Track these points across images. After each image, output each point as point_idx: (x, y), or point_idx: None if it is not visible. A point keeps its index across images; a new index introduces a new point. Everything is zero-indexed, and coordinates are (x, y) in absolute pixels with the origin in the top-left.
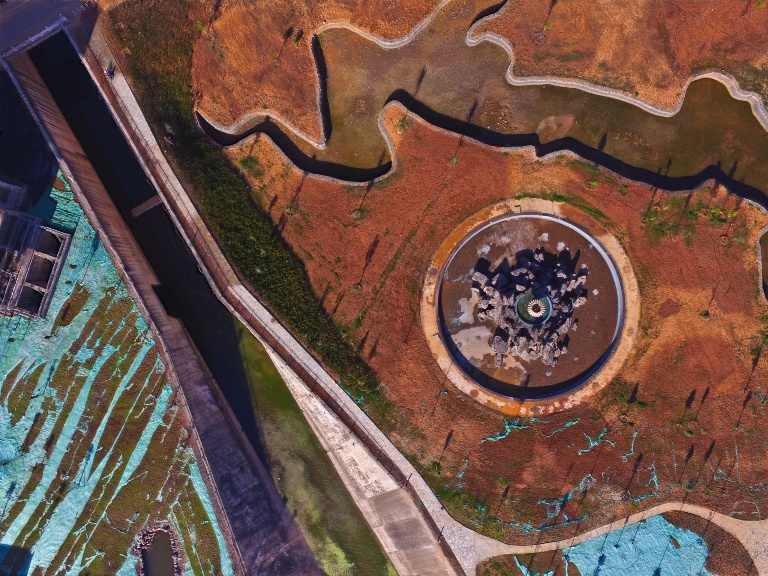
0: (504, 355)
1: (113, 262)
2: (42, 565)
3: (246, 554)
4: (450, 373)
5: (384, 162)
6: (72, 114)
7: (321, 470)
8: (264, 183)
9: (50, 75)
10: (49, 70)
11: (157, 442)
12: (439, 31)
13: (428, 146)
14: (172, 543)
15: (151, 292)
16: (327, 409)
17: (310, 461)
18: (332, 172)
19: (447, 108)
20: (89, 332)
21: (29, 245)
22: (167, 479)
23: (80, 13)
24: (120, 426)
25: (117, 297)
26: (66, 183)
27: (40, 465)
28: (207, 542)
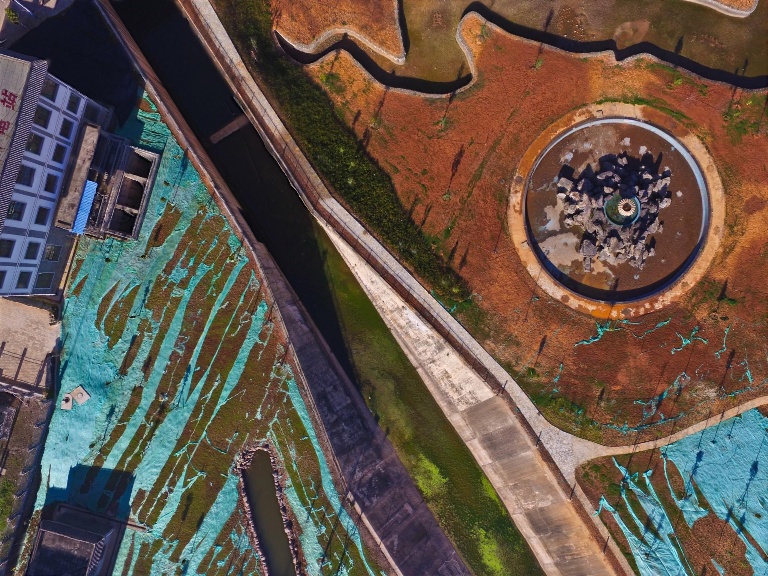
0: (592, 260)
1: (203, 181)
2: (144, 488)
3: (345, 469)
4: (540, 280)
5: (463, 75)
6: (142, 47)
7: (411, 387)
8: (346, 99)
9: (119, 8)
10: (118, 3)
11: (254, 360)
12: None
13: (508, 55)
14: (272, 461)
15: (239, 213)
16: (421, 319)
17: (400, 379)
18: (412, 87)
19: (523, 18)
20: (182, 252)
21: (120, 166)
22: (265, 396)
23: None
24: (217, 345)
25: (209, 216)
26: (152, 104)
27: (139, 387)
28: (307, 458)
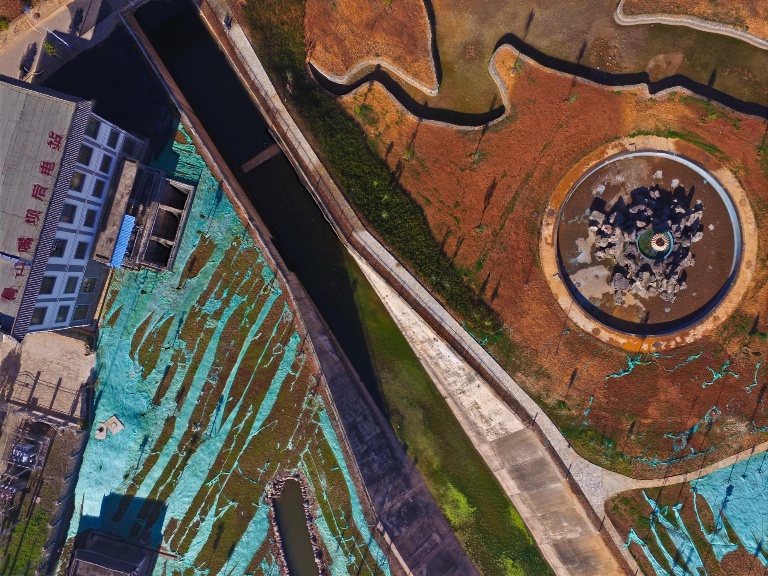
0: (623, 293)
1: (237, 213)
2: (176, 517)
3: (375, 499)
4: (571, 312)
5: (496, 106)
6: (173, 74)
7: (440, 417)
8: (379, 131)
9: (152, 36)
10: (150, 31)
11: (286, 390)
12: None
13: (541, 88)
14: (303, 491)
15: (271, 243)
16: (453, 352)
17: (429, 408)
18: (444, 118)
19: (556, 50)
20: (216, 283)
21: (155, 198)
22: (297, 427)
23: None
24: (249, 376)
25: (242, 247)
26: (187, 136)
27: (172, 417)
28: (338, 488)
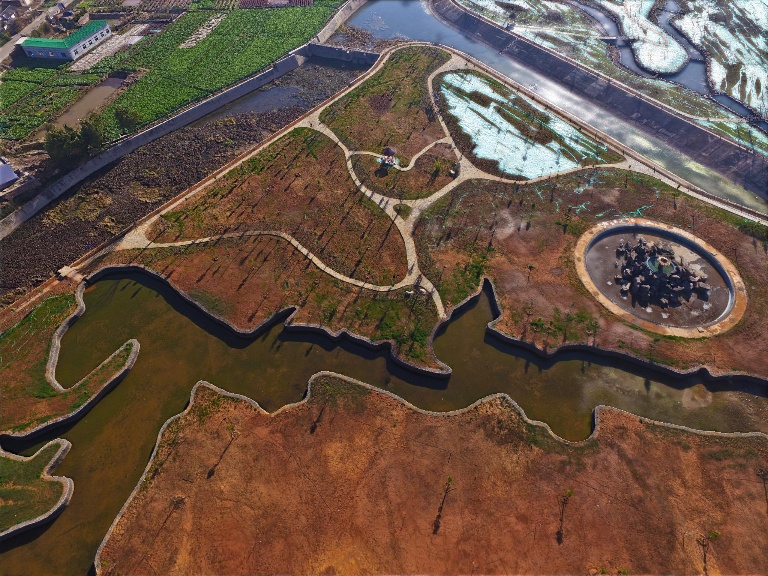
0: None
1: None
2: None
3: (761, 161)
4: (692, 236)
5: None
6: None
7: None
8: None
9: None
10: None
11: None
12: None
13: None
14: None
15: None
16: (766, 215)
17: (743, 205)
18: None
19: None
20: None
21: None
22: None
23: None
24: None
25: None
26: None
27: None
28: None
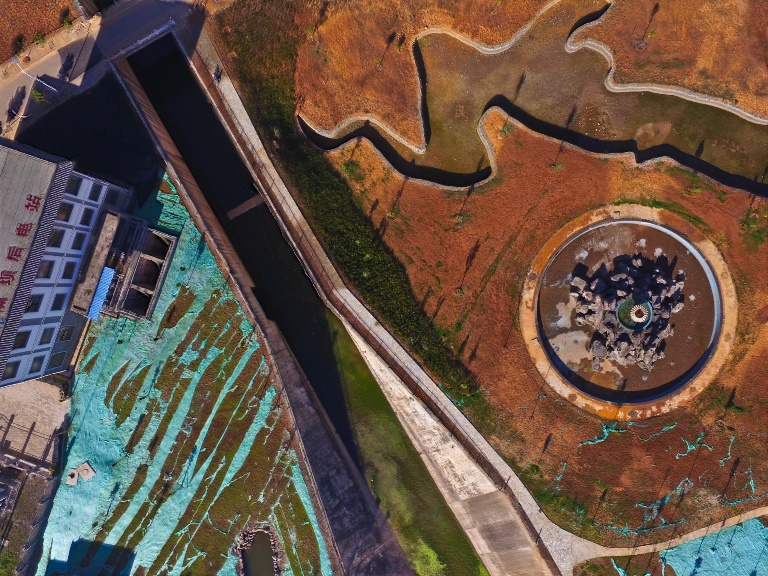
0: (601, 359)
1: (219, 265)
2: (144, 565)
3: (344, 555)
4: (549, 377)
5: (483, 167)
6: (164, 116)
7: (414, 472)
8: (365, 187)
9: (144, 77)
10: (142, 72)
11: (260, 444)
12: (538, 37)
13: (529, 152)
14: (272, 544)
15: (252, 295)
16: (428, 412)
17: (403, 463)
18: (431, 177)
19: (546, 114)
20: (194, 334)
21: (137, 247)
22: (269, 480)
23: (187, 16)
24: (223, 428)
25: (222, 300)
26: (172, 186)
27: (144, 466)
28: (307, 543)
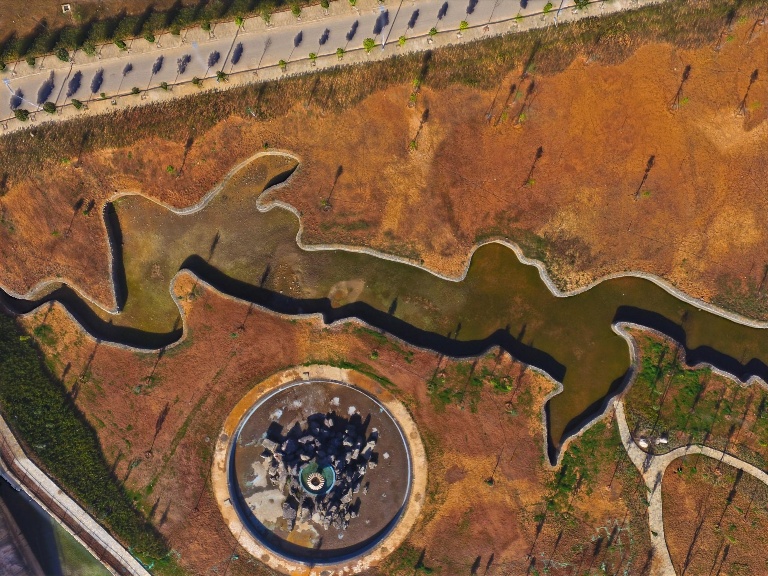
0: (297, 518)
1: None
2: None
3: None
4: (241, 538)
5: (179, 326)
6: None
7: None
8: (58, 351)
9: None
10: None
11: None
12: (232, 197)
13: (218, 314)
14: None
15: None
16: None
17: None
18: (128, 337)
19: (240, 273)
20: None
21: None
22: None
23: None
24: None
25: None
26: None
27: None
28: None
